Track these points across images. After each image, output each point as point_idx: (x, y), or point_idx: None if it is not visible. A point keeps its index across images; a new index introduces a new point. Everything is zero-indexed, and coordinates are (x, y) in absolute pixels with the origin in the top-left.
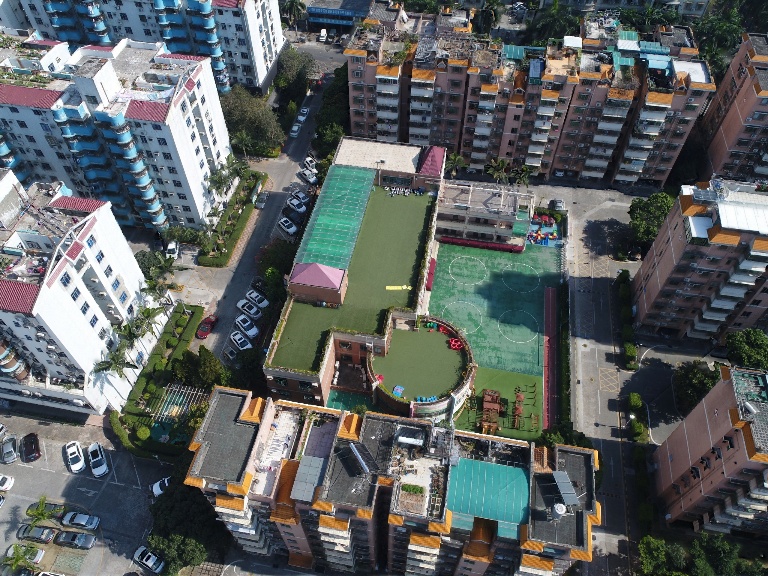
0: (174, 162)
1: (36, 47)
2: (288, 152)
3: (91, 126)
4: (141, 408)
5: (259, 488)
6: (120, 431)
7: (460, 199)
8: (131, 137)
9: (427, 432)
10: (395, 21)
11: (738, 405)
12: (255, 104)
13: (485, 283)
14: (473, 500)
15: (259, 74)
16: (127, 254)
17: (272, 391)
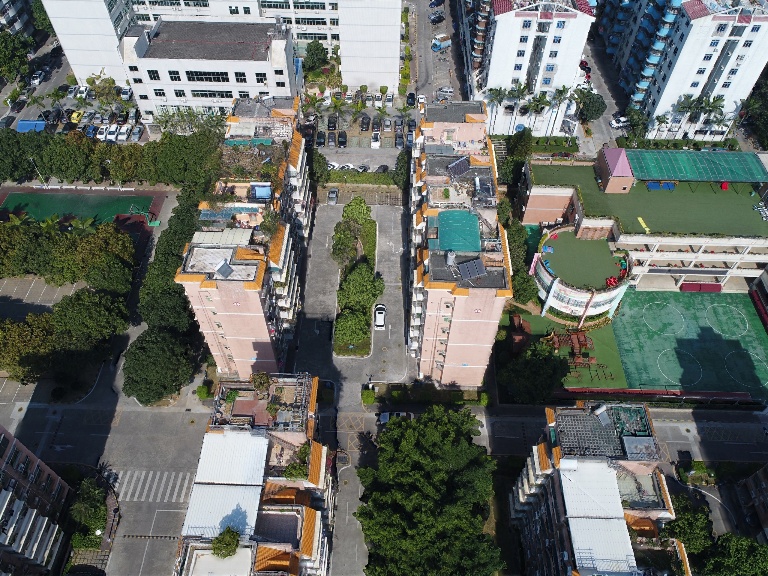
0: (675, 58)
1: None
2: None
3: None
4: None
5: (430, 143)
6: None
7: None
8: (673, 21)
9: None
10: None
11: None
12: None
13: (719, 336)
14: (448, 223)
15: None
16: (575, 62)
17: (519, 184)
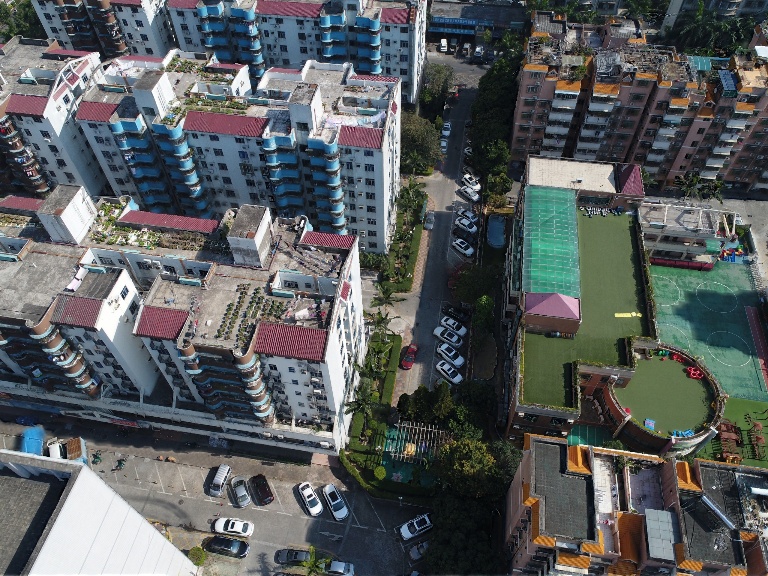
0: (375, 188)
1: (220, 71)
2: (441, 169)
3: (295, 153)
4: (364, 445)
5: None
6: (355, 471)
7: (651, 217)
8: (339, 164)
9: None
10: (565, 33)
11: None
12: (417, 122)
13: (682, 303)
14: None
15: (414, 90)
16: (359, 288)
17: (515, 427)
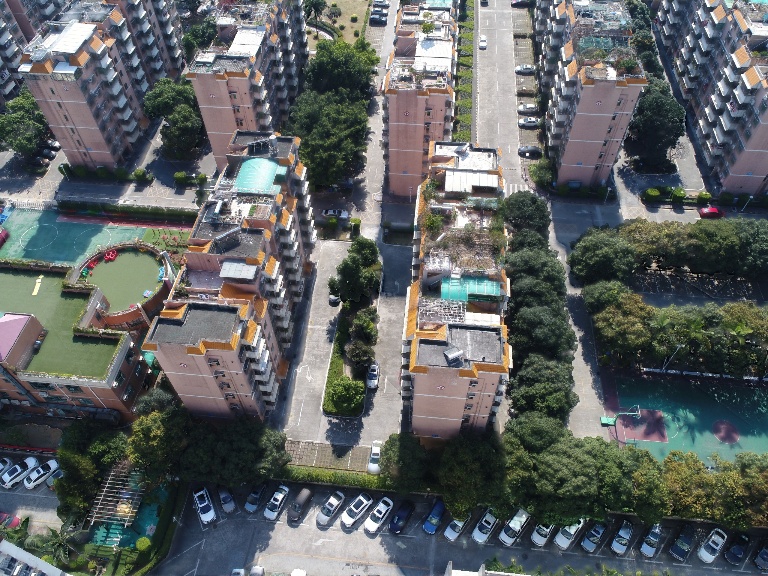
0: None
1: None
2: None
3: None
4: None
5: None
6: (135, 575)
7: None
8: None
9: (211, 203)
10: None
11: (214, 73)
12: None
13: None
14: (262, 183)
15: None
16: None
17: (125, 398)
